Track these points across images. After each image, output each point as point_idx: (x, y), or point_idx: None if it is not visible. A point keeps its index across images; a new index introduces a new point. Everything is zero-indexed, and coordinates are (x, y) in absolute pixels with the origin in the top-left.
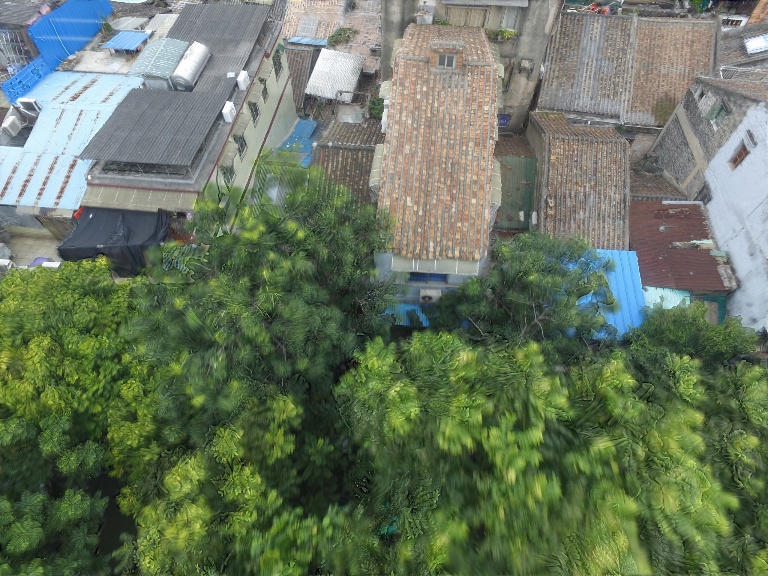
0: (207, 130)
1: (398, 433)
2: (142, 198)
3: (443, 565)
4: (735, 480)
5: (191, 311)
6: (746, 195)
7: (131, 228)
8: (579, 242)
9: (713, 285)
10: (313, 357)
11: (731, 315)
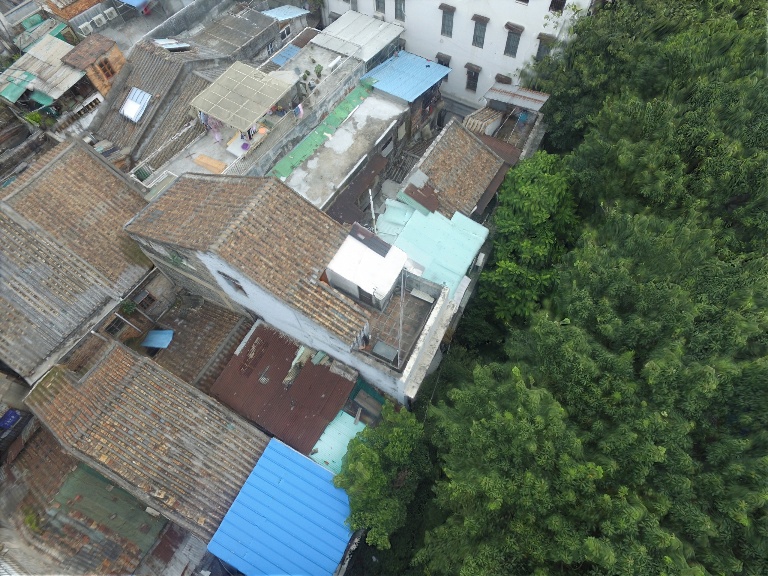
0: None
1: None
2: None
3: None
4: None
5: None
6: None
7: None
8: None
9: (345, 389)
10: None
11: (377, 387)
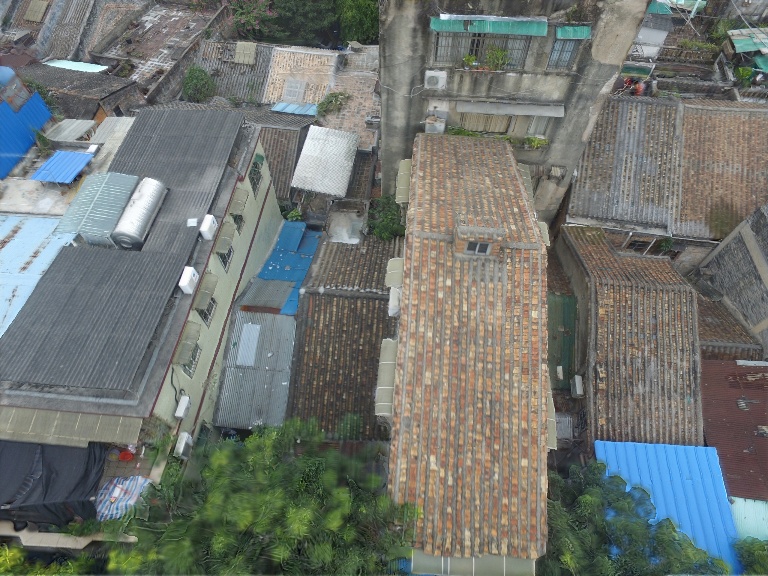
0: (156, 321)
1: None
2: (67, 425)
3: None
4: None
5: None
6: None
7: (53, 465)
8: (682, 545)
9: None
10: None
11: None
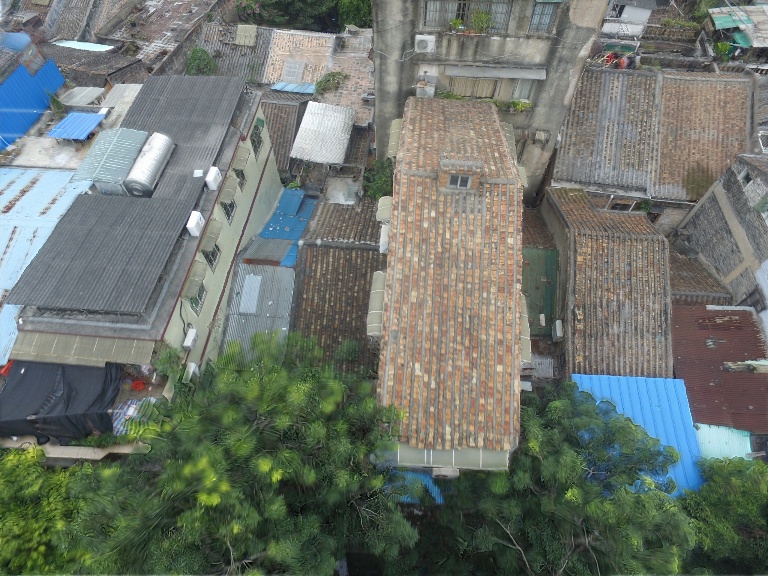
0: (167, 256)
1: None
2: (86, 348)
3: None
4: None
5: None
6: None
7: (73, 385)
8: (638, 433)
9: None
10: None
11: None
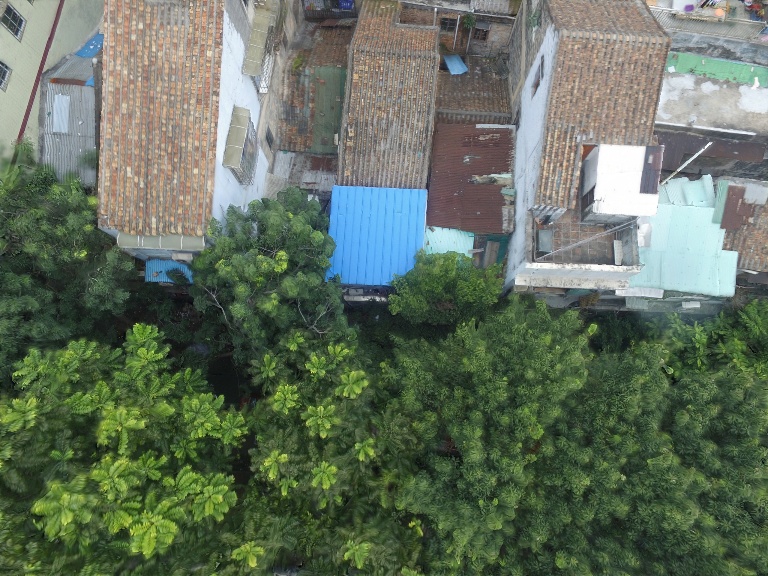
0: None
1: None
2: None
3: None
4: (281, 489)
5: None
6: (531, 134)
7: None
8: (292, 221)
9: (493, 227)
10: (25, 347)
11: (509, 255)
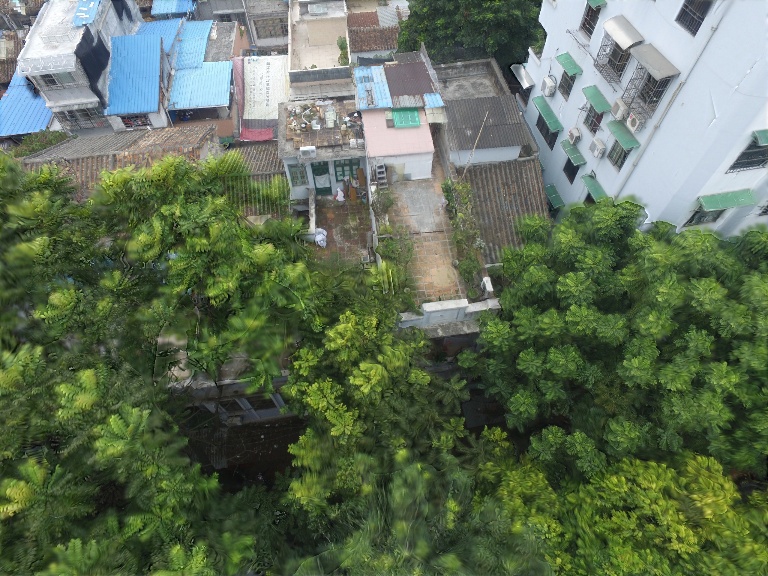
0: None
1: (60, 343)
2: None
3: (35, 253)
4: None
5: (442, 570)
6: None
7: None
8: None
9: None
10: None
11: None
